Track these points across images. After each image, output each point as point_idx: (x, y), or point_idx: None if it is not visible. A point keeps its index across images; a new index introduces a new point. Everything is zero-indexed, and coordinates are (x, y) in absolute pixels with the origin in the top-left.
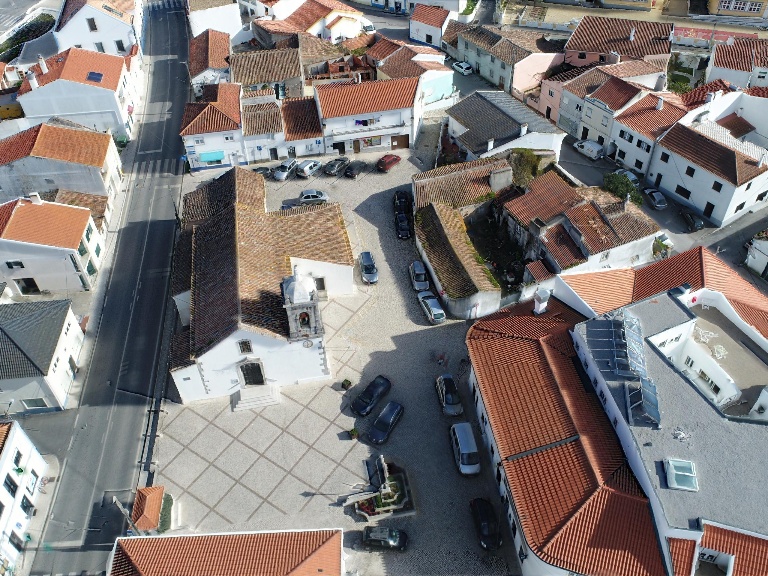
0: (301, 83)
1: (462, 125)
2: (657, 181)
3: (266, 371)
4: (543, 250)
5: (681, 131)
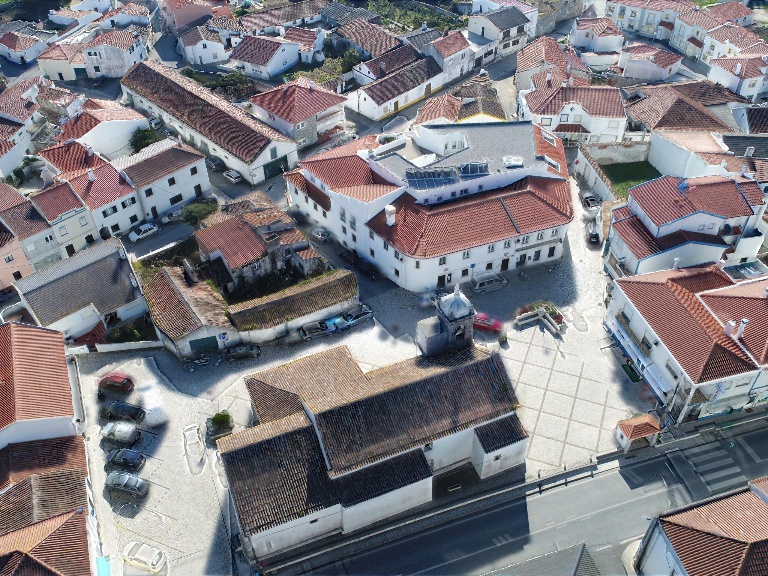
0: None
1: (80, 310)
2: (154, 214)
3: None
4: (287, 249)
5: (134, 171)
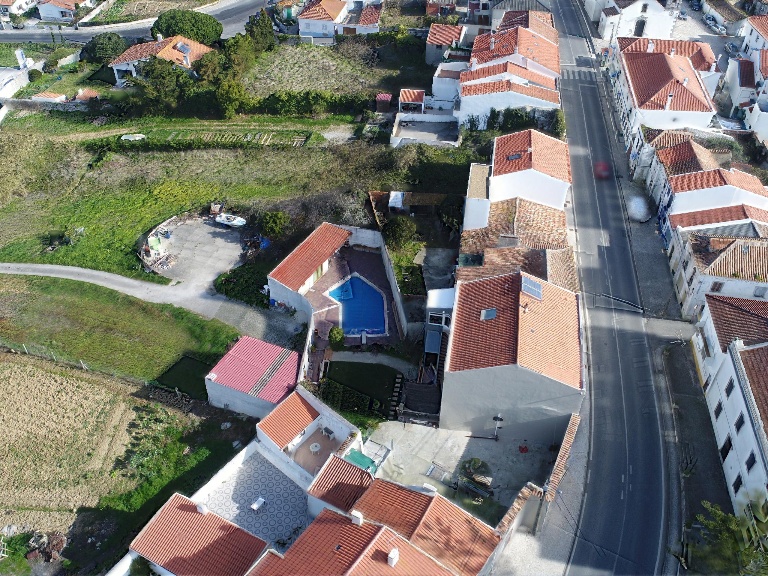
0: None
1: None
2: None
3: (647, 27)
4: None
5: None
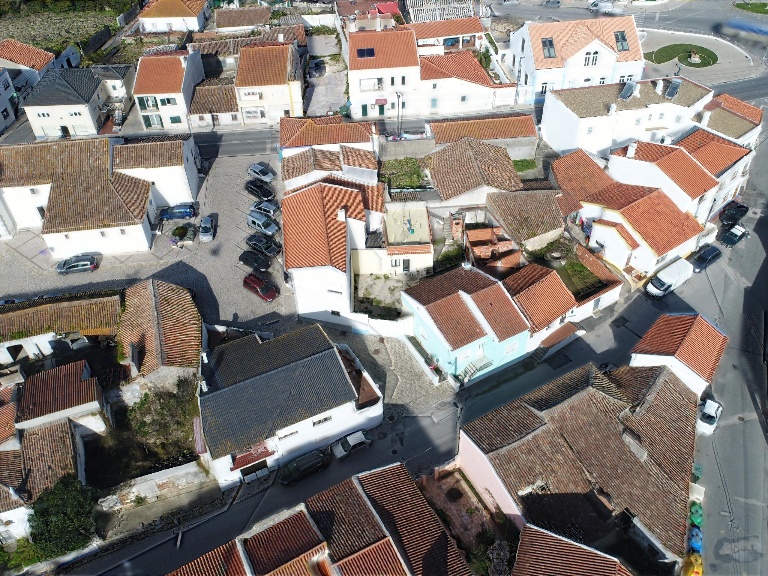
0: (420, 200)
1: None
2: None
3: None
4: None
5: None
